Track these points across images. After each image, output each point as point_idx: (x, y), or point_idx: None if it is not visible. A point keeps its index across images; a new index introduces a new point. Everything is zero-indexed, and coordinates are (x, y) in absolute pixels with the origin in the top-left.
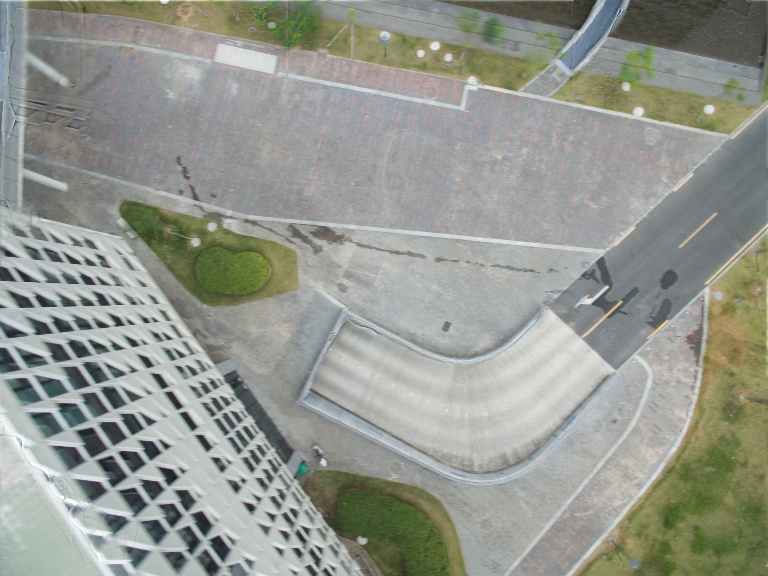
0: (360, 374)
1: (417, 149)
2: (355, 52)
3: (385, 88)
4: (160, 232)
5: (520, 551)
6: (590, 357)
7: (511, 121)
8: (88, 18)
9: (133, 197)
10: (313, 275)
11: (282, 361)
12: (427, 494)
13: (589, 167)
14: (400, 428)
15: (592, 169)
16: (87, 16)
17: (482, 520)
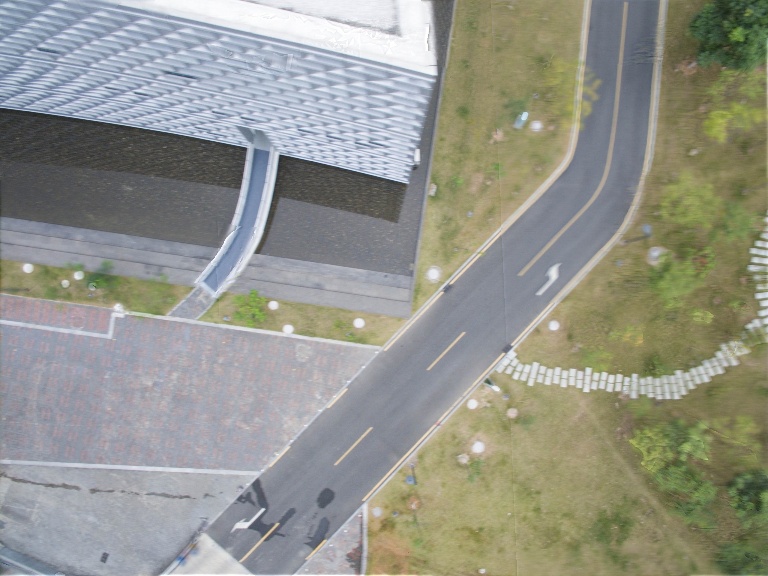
0: None
1: (67, 380)
2: None
3: (32, 320)
4: None
5: None
6: None
7: (160, 346)
8: None
9: None
10: None
11: None
12: None
13: (240, 388)
14: None
15: (244, 390)
16: None
17: None
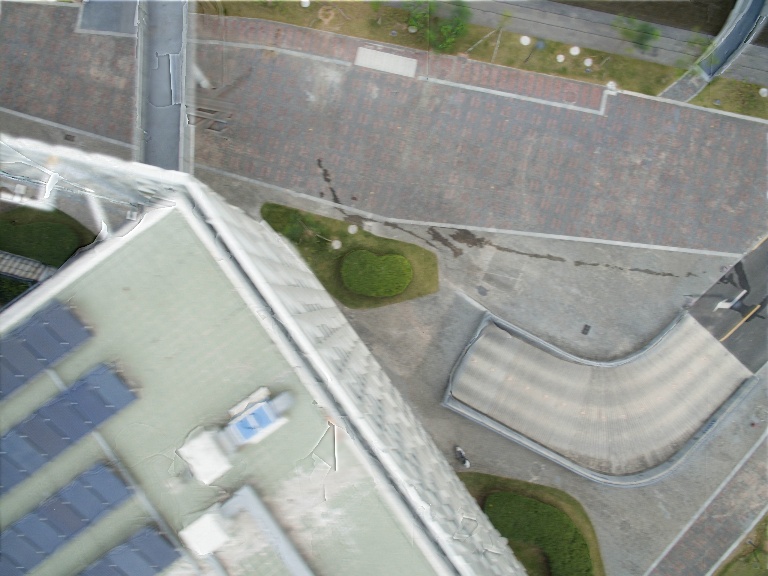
0: (493, 376)
1: (557, 153)
2: (496, 56)
3: (525, 92)
4: (302, 234)
5: (658, 553)
6: (728, 361)
7: (650, 126)
8: (229, 21)
9: (274, 199)
10: (453, 278)
11: (423, 363)
12: (567, 496)
13: (727, 172)
14: (535, 430)
15: (730, 174)
16: (228, 19)
17: (621, 522)
